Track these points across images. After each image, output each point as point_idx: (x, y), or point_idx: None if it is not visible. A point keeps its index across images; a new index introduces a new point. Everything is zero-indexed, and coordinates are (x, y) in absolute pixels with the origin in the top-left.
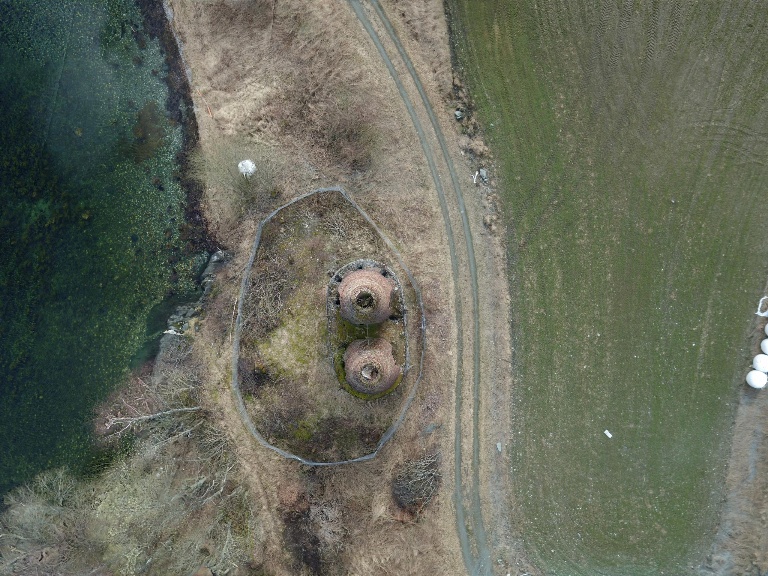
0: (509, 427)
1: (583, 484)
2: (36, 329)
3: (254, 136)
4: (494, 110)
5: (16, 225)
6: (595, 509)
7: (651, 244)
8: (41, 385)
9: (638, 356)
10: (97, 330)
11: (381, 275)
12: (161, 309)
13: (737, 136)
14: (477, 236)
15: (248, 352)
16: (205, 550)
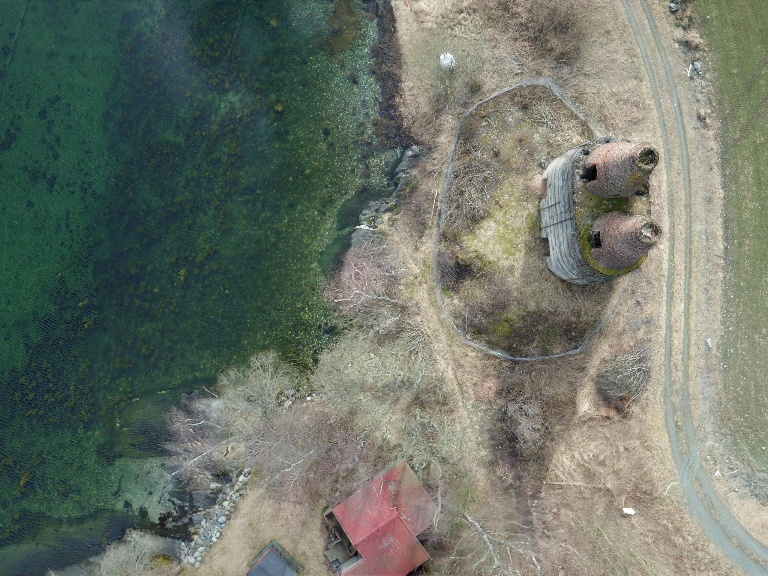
0: (720, 323)
1: None
2: (224, 222)
3: (454, 29)
4: (711, 2)
5: (206, 116)
6: None
7: None
8: (227, 279)
9: None
10: (286, 224)
11: None
12: (352, 204)
13: None
14: (690, 129)
15: (448, 245)
16: (398, 446)
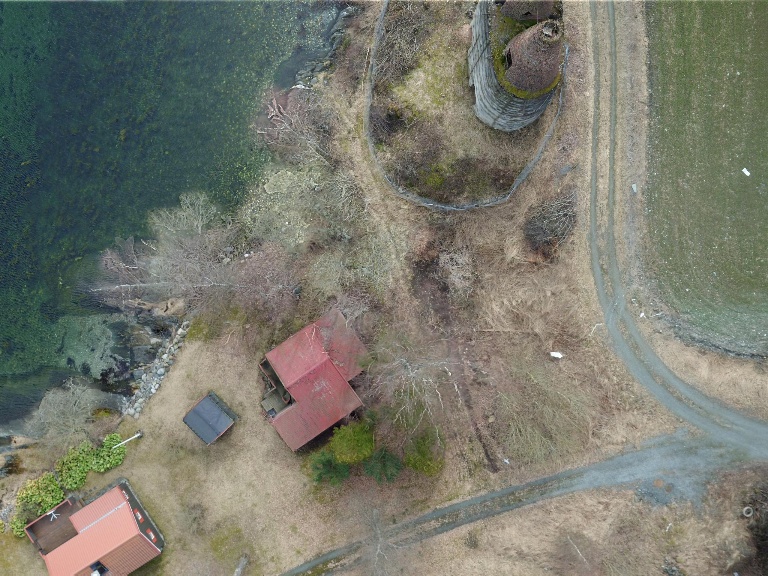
0: (644, 169)
1: (719, 223)
2: (163, 84)
3: None
4: None
5: None
6: (731, 247)
7: None
8: (167, 140)
9: None
10: (224, 86)
11: None
12: (289, 65)
13: None
14: None
15: (380, 99)
16: (333, 298)
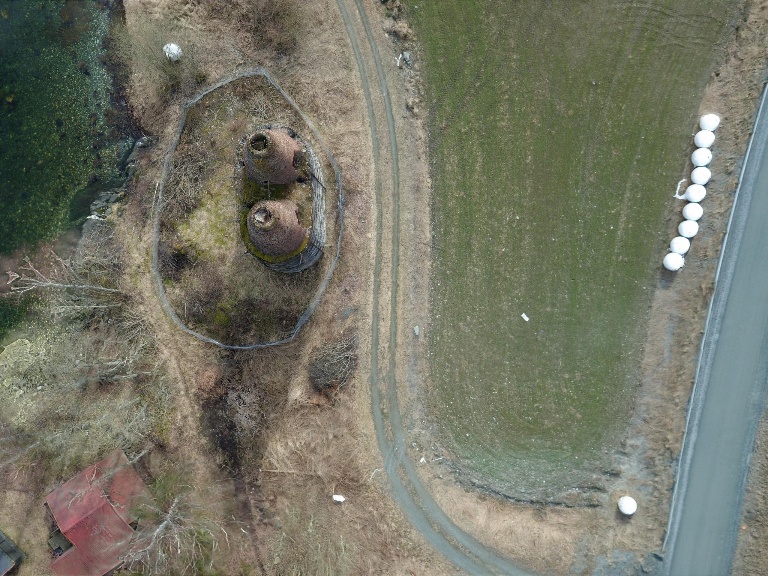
0: (427, 311)
1: (499, 368)
2: None
3: (181, 20)
4: None
5: None
6: (511, 393)
7: (571, 126)
8: None
9: (556, 239)
10: (20, 215)
11: (288, 136)
12: (84, 195)
13: (658, 17)
14: (399, 119)
15: (168, 235)
16: (121, 434)
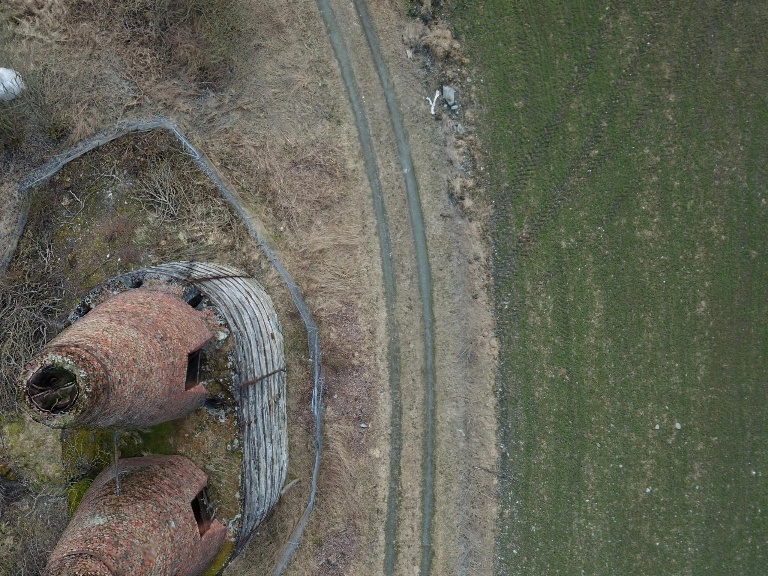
0: None
1: None
2: None
3: (20, 23)
4: None
5: None
6: None
7: None
8: None
9: (759, 472)
10: None
11: (181, 303)
12: None
13: None
14: (434, 219)
15: None
16: None
